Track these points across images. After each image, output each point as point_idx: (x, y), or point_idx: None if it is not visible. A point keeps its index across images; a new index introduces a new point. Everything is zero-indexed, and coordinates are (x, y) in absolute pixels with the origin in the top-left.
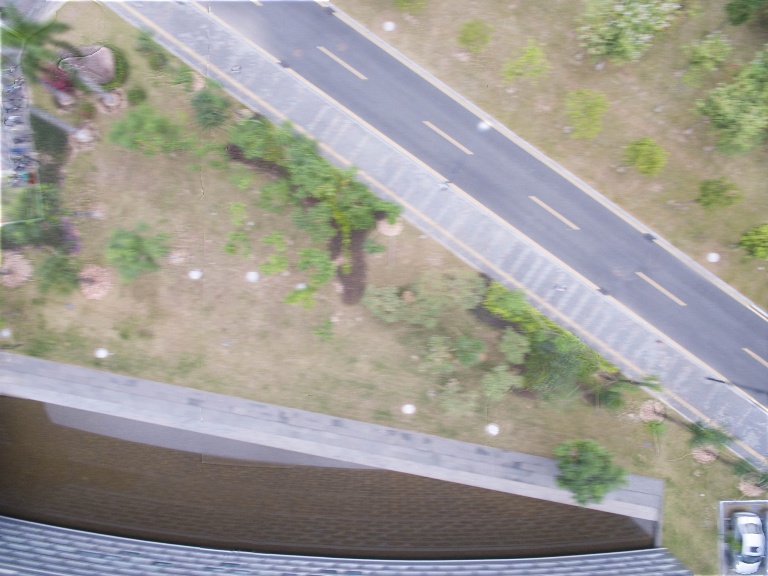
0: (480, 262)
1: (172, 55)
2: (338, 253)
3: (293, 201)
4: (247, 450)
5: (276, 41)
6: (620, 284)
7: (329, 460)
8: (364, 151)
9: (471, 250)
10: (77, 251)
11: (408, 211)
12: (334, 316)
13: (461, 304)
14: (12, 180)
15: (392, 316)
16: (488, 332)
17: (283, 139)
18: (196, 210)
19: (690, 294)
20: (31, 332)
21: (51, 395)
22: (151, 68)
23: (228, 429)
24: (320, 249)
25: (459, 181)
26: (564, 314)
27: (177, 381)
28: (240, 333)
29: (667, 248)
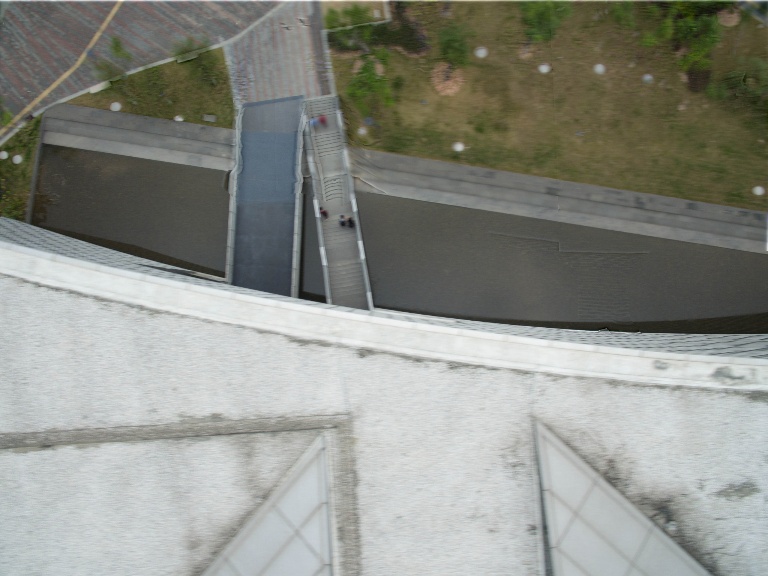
0: None
1: None
2: (684, 42)
3: None
4: (603, 237)
5: None
6: None
7: (684, 243)
8: None
9: None
10: (427, 50)
11: (744, 3)
12: (681, 104)
13: None
14: None
15: (738, 101)
16: None
17: None
18: (541, 7)
19: None
20: (388, 129)
21: (409, 191)
22: None
23: (584, 217)
24: (666, 39)
25: None
26: None
27: (534, 171)
28: (592, 123)
29: None
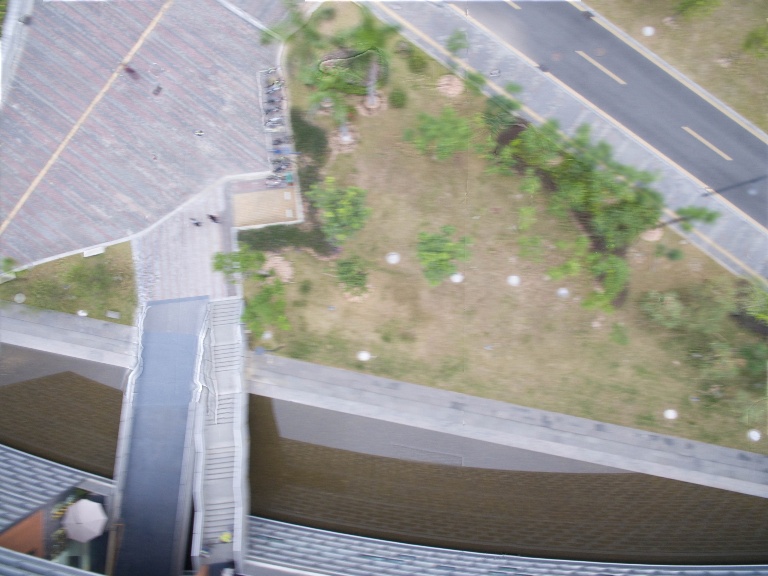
0: (740, 268)
1: (430, 58)
2: (601, 258)
3: (557, 205)
4: (508, 454)
5: (535, 45)
6: None
7: (591, 464)
8: (624, 156)
9: (731, 256)
10: (338, 253)
11: (668, 216)
12: (596, 321)
13: (731, 310)
14: (271, 182)
15: (655, 321)
16: (753, 338)
17: (544, 143)
18: (457, 213)
19: None
20: (293, 334)
21: (312, 397)
22: (410, 71)
23: (489, 433)
24: (583, 254)
25: (718, 187)
26: None
27: (440, 384)
28: (503, 337)
29: None
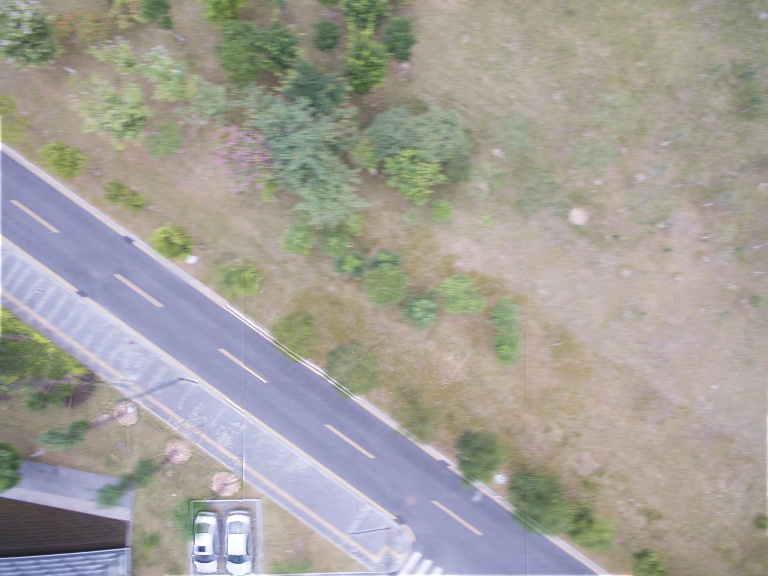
0: None
1: None
2: None
3: None
4: None
5: None
6: (98, 286)
7: None
8: None
9: None
10: None
11: None
12: None
13: None
14: None
15: None
16: None
17: None
18: None
19: (168, 295)
20: None
21: None
22: None
23: None
24: None
25: None
26: (41, 316)
27: None
28: None
29: (145, 250)
